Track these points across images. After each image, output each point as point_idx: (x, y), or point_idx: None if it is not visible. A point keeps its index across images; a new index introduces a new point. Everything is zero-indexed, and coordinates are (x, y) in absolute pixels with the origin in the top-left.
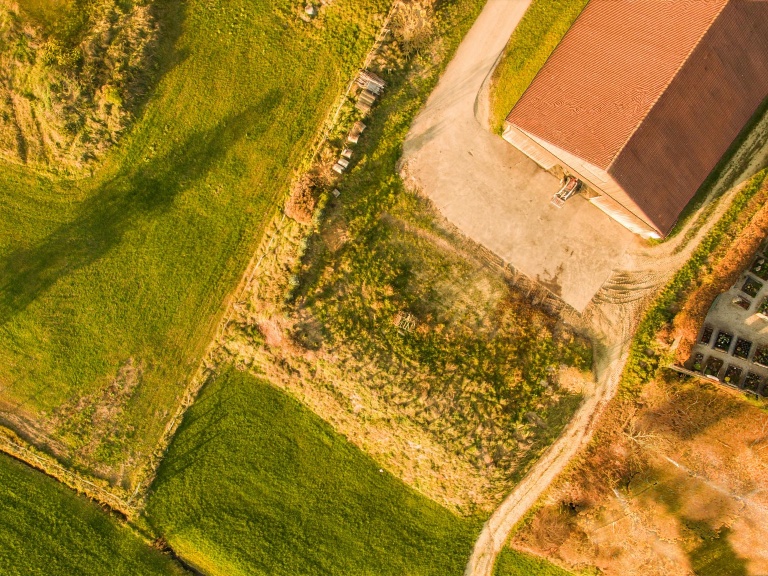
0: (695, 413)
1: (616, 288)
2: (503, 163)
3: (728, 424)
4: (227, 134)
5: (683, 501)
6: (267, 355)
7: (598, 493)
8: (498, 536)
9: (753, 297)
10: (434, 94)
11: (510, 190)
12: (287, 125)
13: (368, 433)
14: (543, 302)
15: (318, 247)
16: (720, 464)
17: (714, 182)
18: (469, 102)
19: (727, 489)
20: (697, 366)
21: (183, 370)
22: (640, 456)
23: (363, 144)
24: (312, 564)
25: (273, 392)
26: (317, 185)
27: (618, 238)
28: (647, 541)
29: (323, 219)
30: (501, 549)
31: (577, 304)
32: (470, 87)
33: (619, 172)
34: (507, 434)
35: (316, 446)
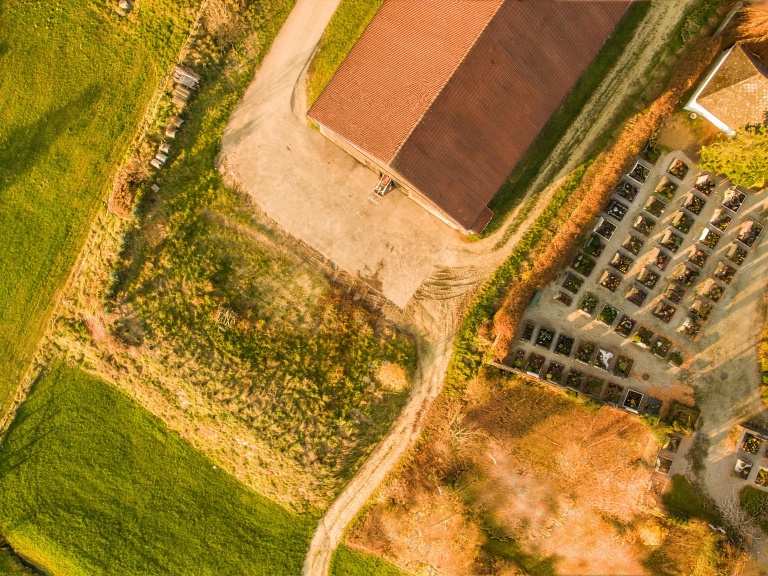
0: (523, 410)
1: (437, 284)
2: (322, 158)
3: (556, 421)
4: (49, 129)
5: (513, 499)
6: (95, 351)
7: (424, 490)
8: (334, 534)
9: (574, 293)
10: (251, 89)
11: (329, 185)
12: (108, 120)
13: (198, 429)
14: (364, 298)
15: (139, 242)
16: (549, 462)
17: (534, 177)
18: (286, 97)
19: (556, 487)
20: (517, 363)
21: (15, 366)
22: (464, 453)
23: (182, 139)
24: (149, 561)
25: (105, 388)
26: (135, 180)
27: (438, 234)
28: (479, 539)
29: (142, 214)
30: (337, 547)
31: (398, 300)
32: (286, 82)
33: (404, 166)
34: (330, 431)
35: (150, 442)
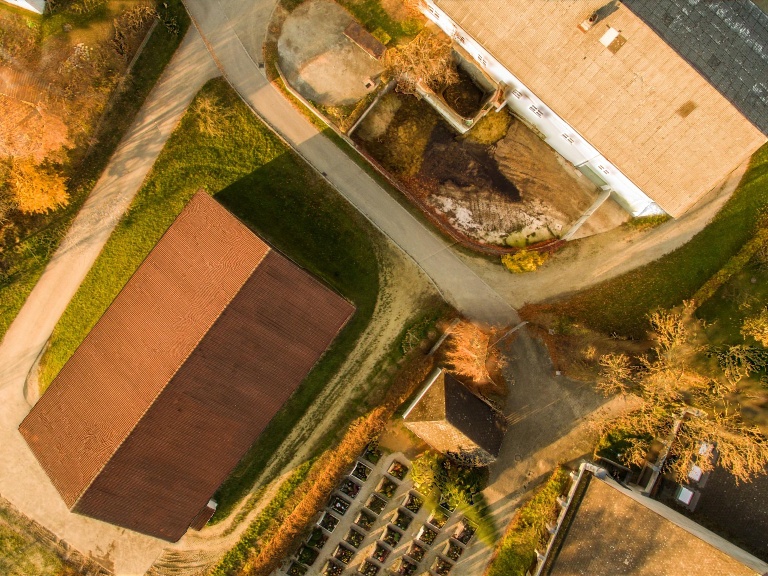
0: None
1: (168, 566)
2: None
3: None
4: None
5: None
6: None
7: None
8: None
9: None
10: None
11: None
12: None
13: None
14: None
15: None
16: None
17: (261, 470)
18: (18, 386)
19: None
20: None
21: None
22: None
23: None
24: None
25: None
26: None
27: None
28: None
29: None
30: None
31: None
32: (19, 372)
33: (89, 509)
34: None
35: None
